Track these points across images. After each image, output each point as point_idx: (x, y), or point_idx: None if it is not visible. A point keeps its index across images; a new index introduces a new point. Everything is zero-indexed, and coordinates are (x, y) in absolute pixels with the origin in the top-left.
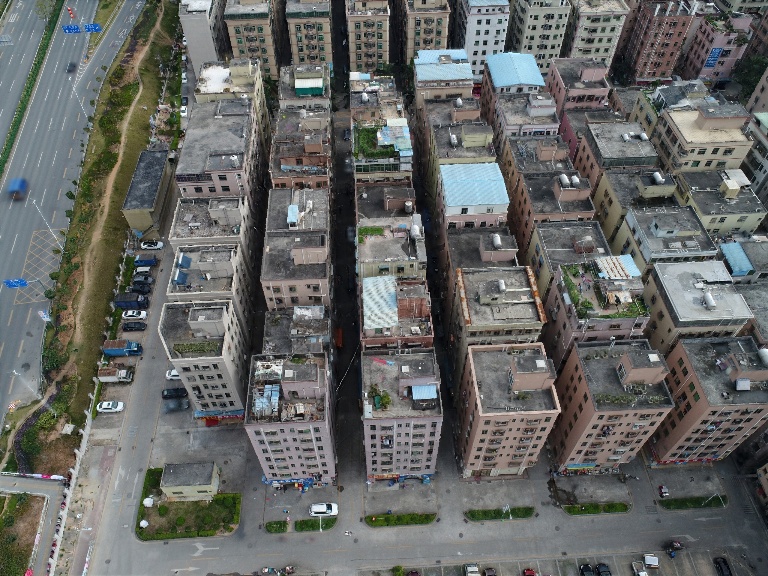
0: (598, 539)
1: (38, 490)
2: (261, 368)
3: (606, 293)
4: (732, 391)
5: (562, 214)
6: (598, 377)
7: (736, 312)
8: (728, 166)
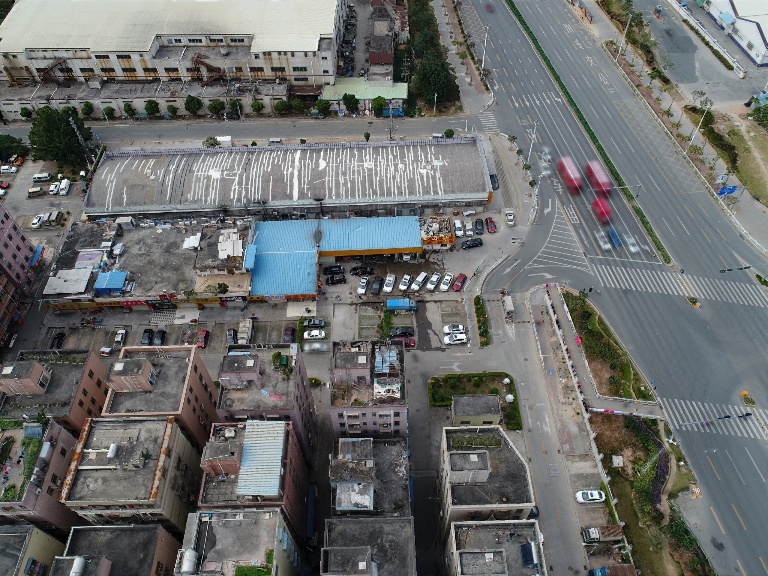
0: None
1: (612, 404)
2: (395, 390)
3: None
4: None
5: None
6: (68, 385)
7: None
8: None
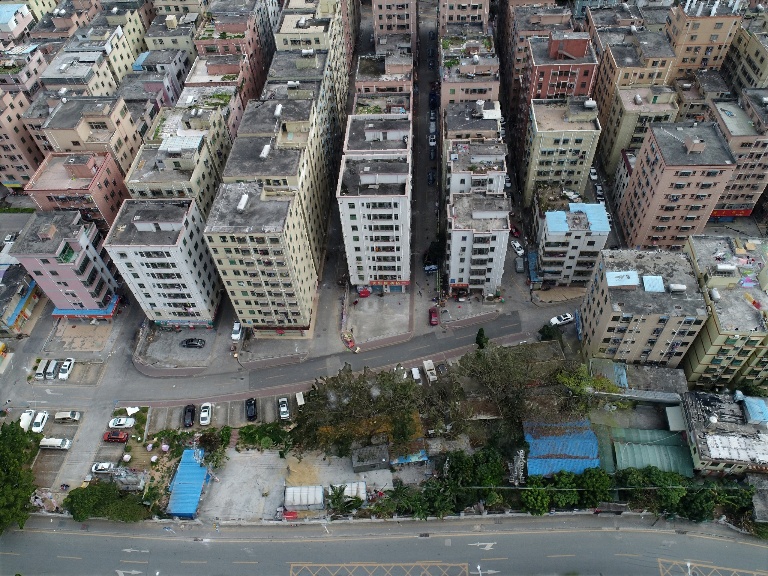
0: (5, 224)
1: None
2: None
3: (0, 61)
4: (47, 115)
5: (47, 33)
6: None
7: (76, 74)
8: (192, 11)
